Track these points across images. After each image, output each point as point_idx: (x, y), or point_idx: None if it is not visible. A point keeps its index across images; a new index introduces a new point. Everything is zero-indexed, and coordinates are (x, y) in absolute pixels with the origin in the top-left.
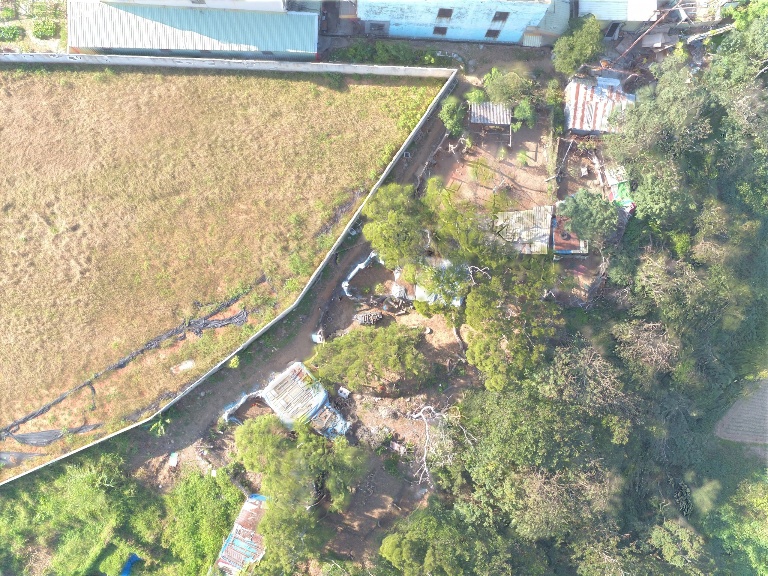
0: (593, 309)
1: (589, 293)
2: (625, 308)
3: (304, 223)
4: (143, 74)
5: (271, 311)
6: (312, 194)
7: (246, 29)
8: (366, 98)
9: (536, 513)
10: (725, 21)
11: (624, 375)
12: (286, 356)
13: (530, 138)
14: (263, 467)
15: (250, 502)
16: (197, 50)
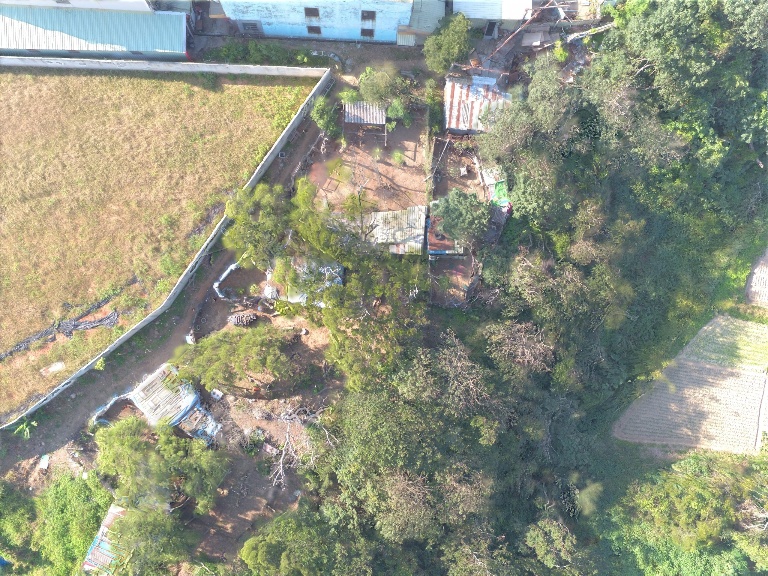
0: (471, 309)
1: (467, 293)
2: (499, 308)
3: (176, 224)
4: (14, 74)
5: (142, 312)
6: (184, 195)
7: (113, 29)
8: (241, 98)
9: (400, 515)
10: (606, 19)
11: (494, 376)
12: (159, 357)
13: (409, 138)
14: None
15: (117, 504)
16: (65, 50)
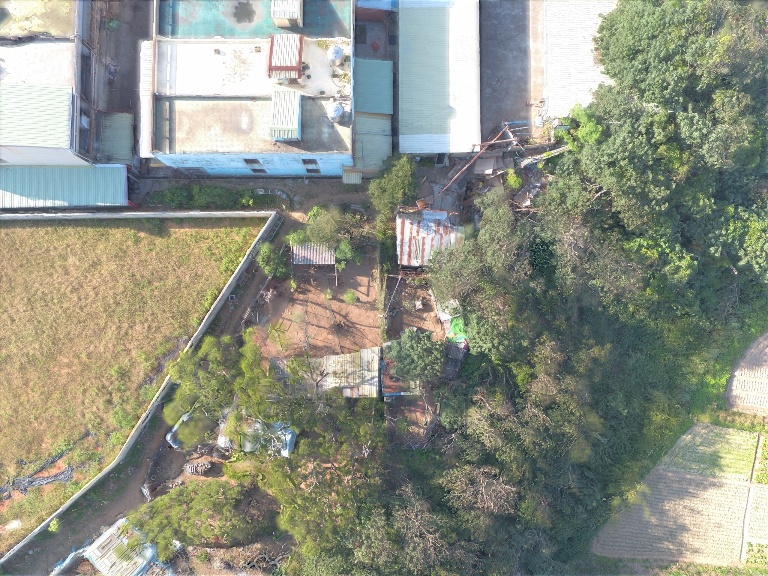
0: (431, 447)
1: None
2: (457, 451)
3: (127, 375)
4: None
5: (95, 466)
6: (134, 345)
7: (55, 185)
8: (188, 242)
9: None
10: (561, 141)
11: (452, 525)
12: (116, 509)
13: (362, 272)
14: None
15: None
16: (8, 207)
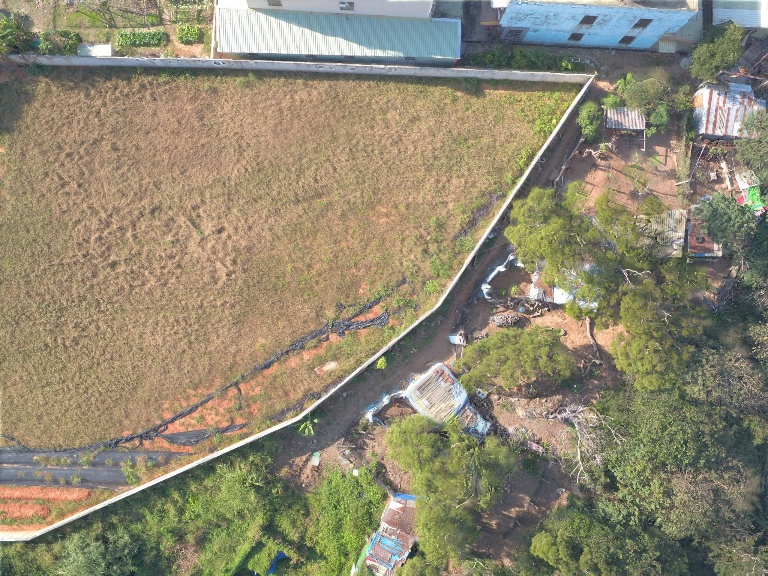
0: (723, 311)
1: (720, 296)
2: (759, 310)
3: (443, 226)
4: (285, 79)
5: (412, 313)
6: (451, 198)
7: (391, 35)
8: (502, 103)
9: (681, 512)
10: None
11: (762, 376)
12: (424, 357)
13: (660, 143)
14: (403, 466)
15: (396, 501)
16: (342, 56)
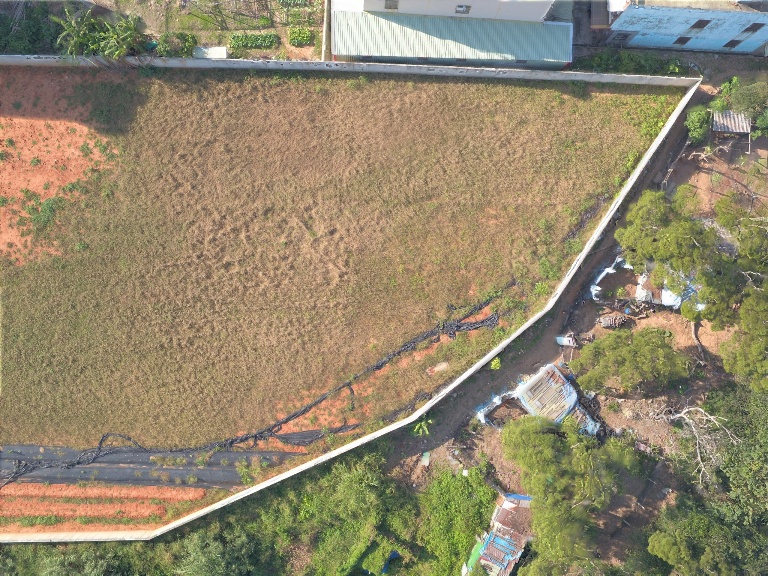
0: None
1: None
2: None
3: (552, 228)
4: (395, 82)
5: (522, 314)
6: (560, 200)
7: (504, 38)
8: (608, 106)
9: None
10: None
11: None
12: (532, 358)
13: (762, 146)
14: (512, 467)
15: (509, 501)
16: (455, 59)
